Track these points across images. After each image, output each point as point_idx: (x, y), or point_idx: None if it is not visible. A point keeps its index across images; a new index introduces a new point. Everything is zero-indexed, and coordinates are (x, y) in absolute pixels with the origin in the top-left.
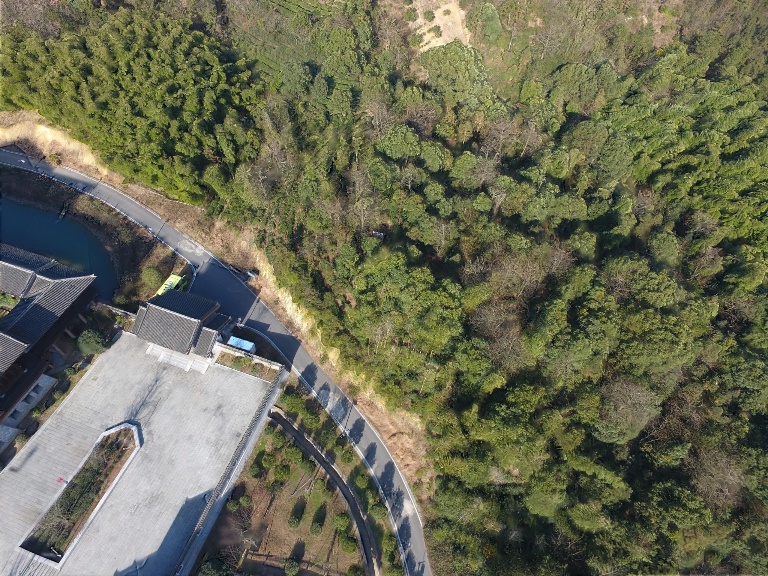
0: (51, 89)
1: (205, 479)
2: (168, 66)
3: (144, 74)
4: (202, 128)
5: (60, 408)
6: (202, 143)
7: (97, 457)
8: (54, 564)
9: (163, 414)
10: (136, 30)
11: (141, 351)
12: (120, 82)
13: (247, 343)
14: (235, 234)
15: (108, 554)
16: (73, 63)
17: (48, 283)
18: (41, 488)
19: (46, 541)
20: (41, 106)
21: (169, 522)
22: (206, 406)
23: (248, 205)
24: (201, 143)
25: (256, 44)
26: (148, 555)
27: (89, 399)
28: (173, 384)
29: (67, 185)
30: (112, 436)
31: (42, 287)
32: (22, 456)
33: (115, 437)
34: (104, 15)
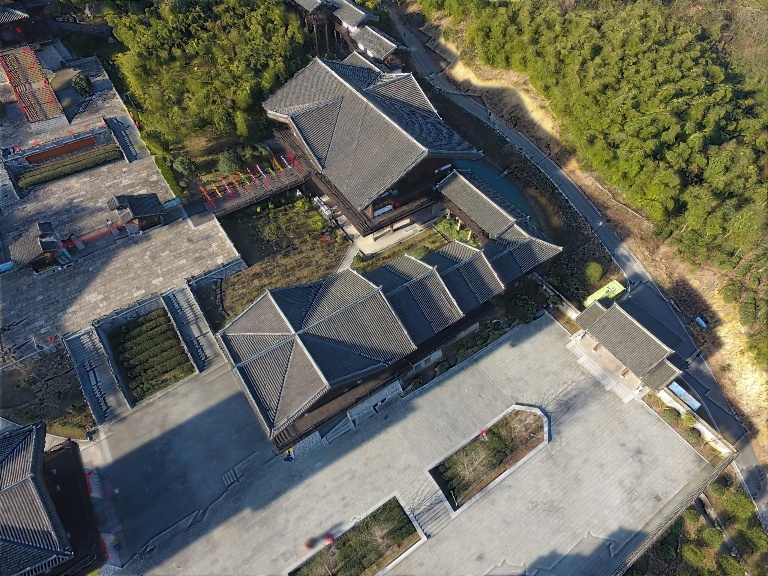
0: (557, 58)
1: (613, 525)
2: (677, 69)
3: (649, 70)
4: (703, 144)
5: (477, 355)
6: (688, 159)
7: (505, 426)
8: (451, 510)
9: (575, 422)
10: (649, 25)
11: (561, 342)
12: (624, 70)
13: (693, 399)
14: (687, 268)
15: (500, 536)
16: (584, 40)
17: (523, 236)
18: (452, 425)
19: (448, 481)
20: (539, 70)
21: (566, 547)
22: (624, 441)
23: (714, 244)
24: (688, 158)
25: (759, 74)
26: (539, 568)
27: (504, 362)
28: (590, 395)
29: (519, 149)
30: (521, 413)
31: (515, 237)
32: (440, 382)
33: (524, 416)
34: (619, 3)
